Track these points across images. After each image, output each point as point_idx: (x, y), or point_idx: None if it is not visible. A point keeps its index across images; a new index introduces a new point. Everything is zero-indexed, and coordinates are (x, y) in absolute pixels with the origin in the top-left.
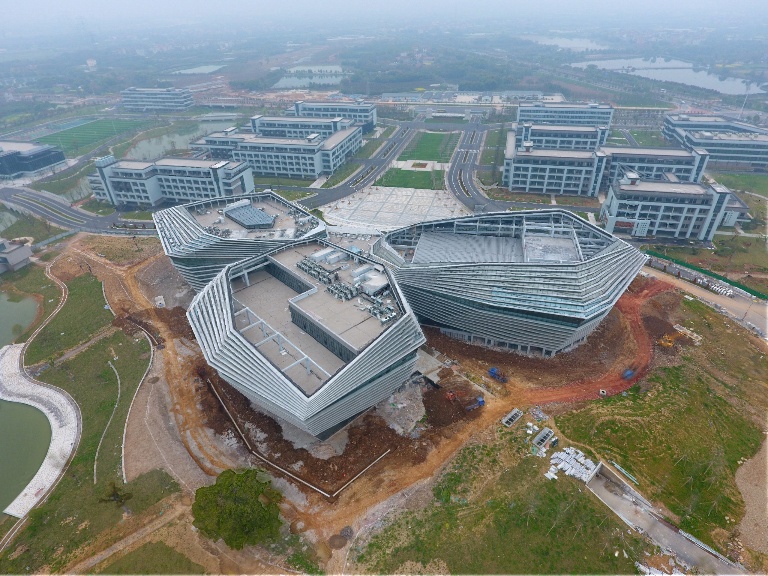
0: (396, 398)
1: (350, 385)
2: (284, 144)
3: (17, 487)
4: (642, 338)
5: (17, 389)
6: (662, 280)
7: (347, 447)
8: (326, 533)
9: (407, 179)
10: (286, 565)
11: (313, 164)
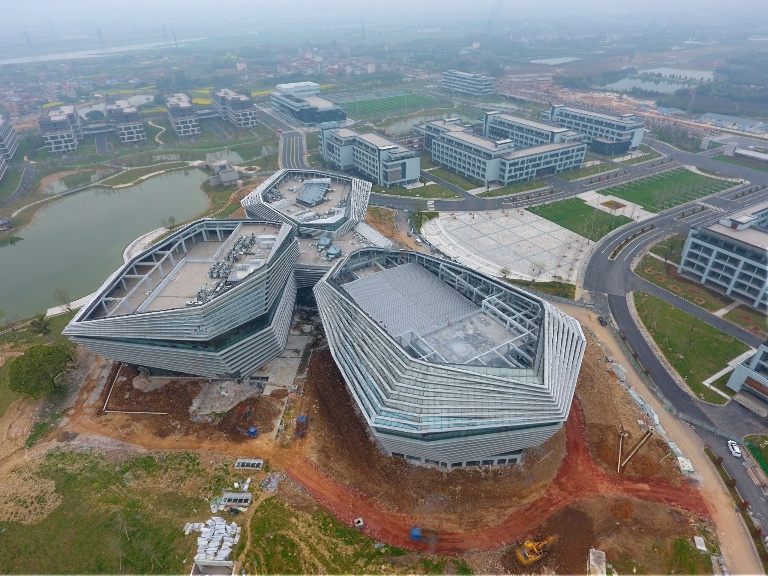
0: (227, 385)
1: (111, 332)
2: (470, 143)
3: (66, 301)
4: (521, 523)
5: (133, 253)
6: (702, 493)
7: (152, 390)
8: (69, 427)
9: (571, 214)
10: (33, 424)
11: (485, 169)
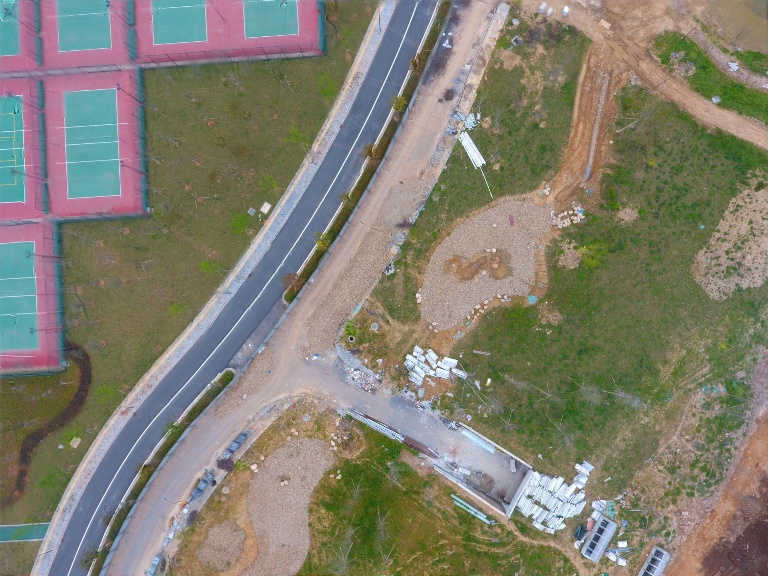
0: None
1: None
2: None
3: None
4: None
5: None
6: None
7: None
8: None
9: None
10: None
11: None
